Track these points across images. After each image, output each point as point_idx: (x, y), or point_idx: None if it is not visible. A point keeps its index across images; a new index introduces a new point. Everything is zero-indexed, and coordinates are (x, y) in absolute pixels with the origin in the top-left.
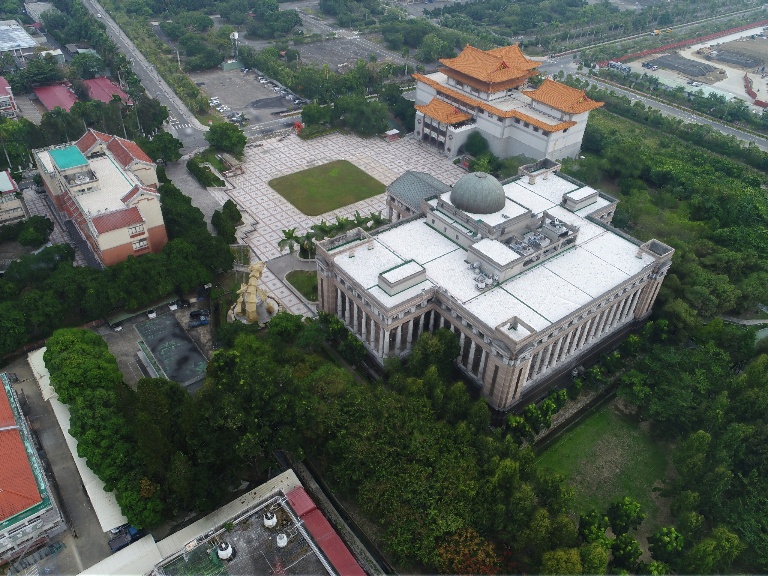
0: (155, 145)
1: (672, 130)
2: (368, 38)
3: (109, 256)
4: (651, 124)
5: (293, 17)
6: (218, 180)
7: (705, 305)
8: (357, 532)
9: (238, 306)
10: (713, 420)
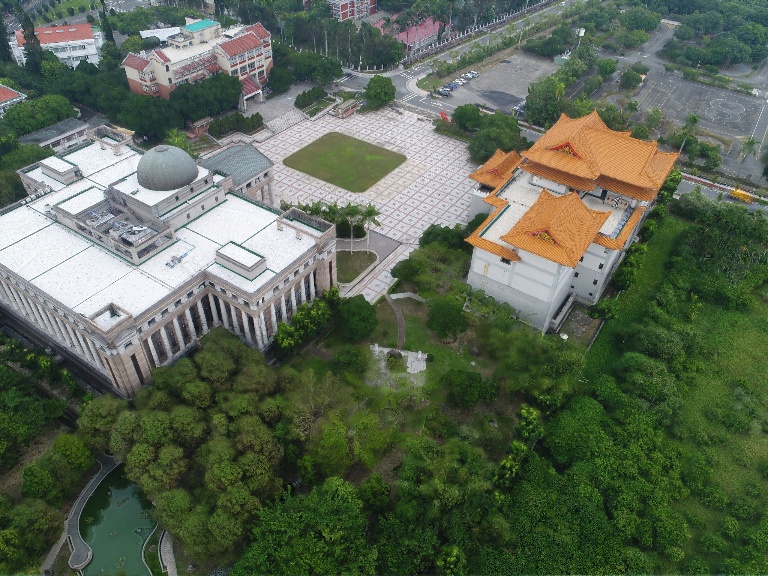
0: (313, 62)
1: None
2: None
3: (131, 84)
4: None
5: (732, 51)
6: (317, 110)
7: None
8: None
9: None
10: None
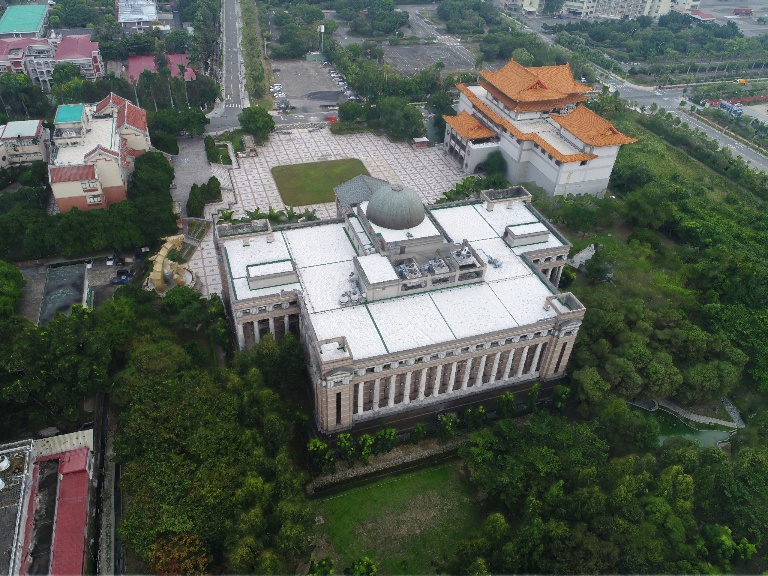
0: (180, 117)
1: (755, 186)
2: (468, 46)
3: (63, 205)
4: (730, 175)
5: (399, 18)
6: (228, 158)
7: (625, 382)
8: (120, 506)
9: None
10: (529, 508)
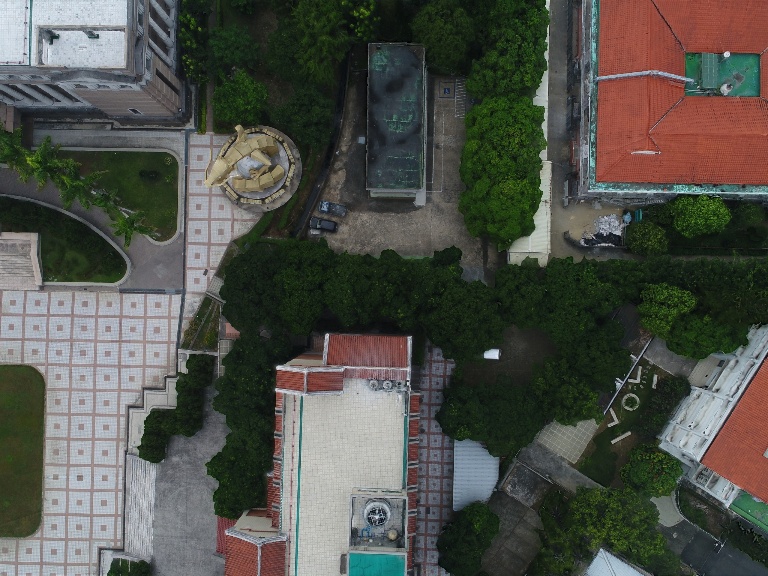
0: None
1: None
2: None
3: None
4: None
5: None
6: None
7: None
8: None
9: (277, 174)
10: None
